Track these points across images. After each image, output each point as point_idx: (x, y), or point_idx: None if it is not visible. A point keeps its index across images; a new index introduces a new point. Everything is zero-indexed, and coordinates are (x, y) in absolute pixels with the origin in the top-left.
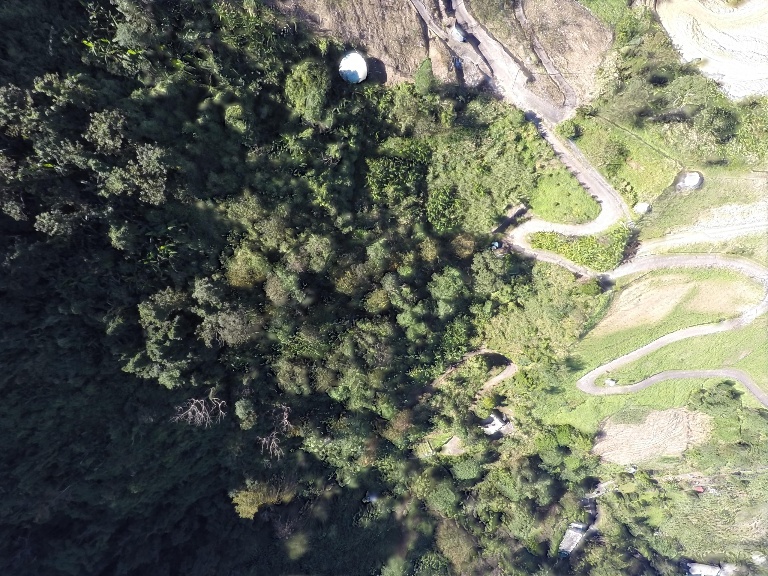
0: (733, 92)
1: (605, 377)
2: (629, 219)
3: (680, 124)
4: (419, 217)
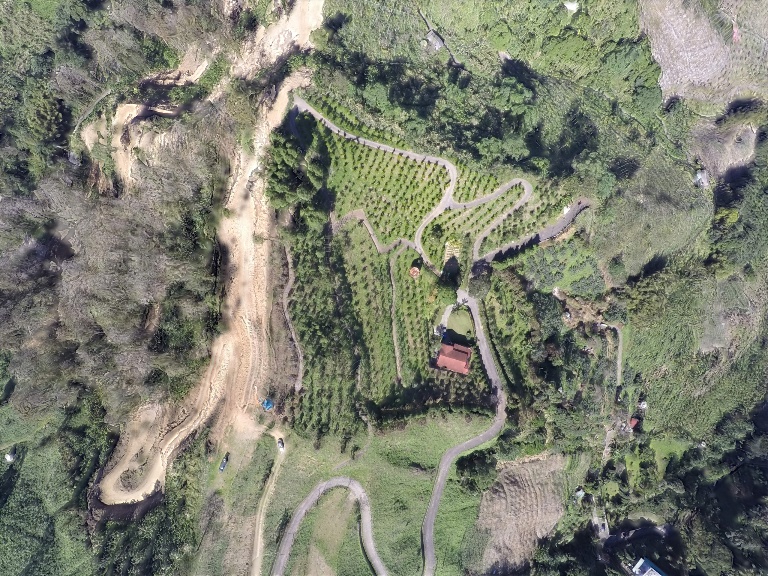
0: None
1: None
2: None
3: None
4: None
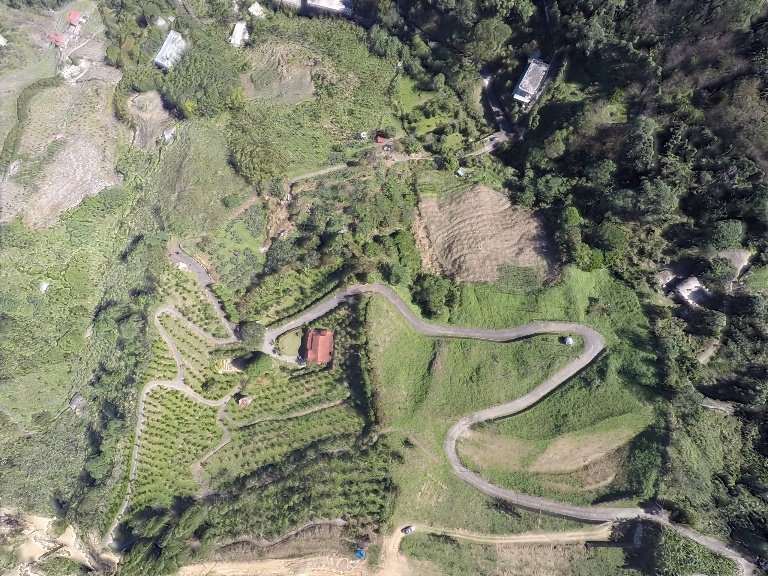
0: None
1: (574, 347)
2: None
3: None
4: None
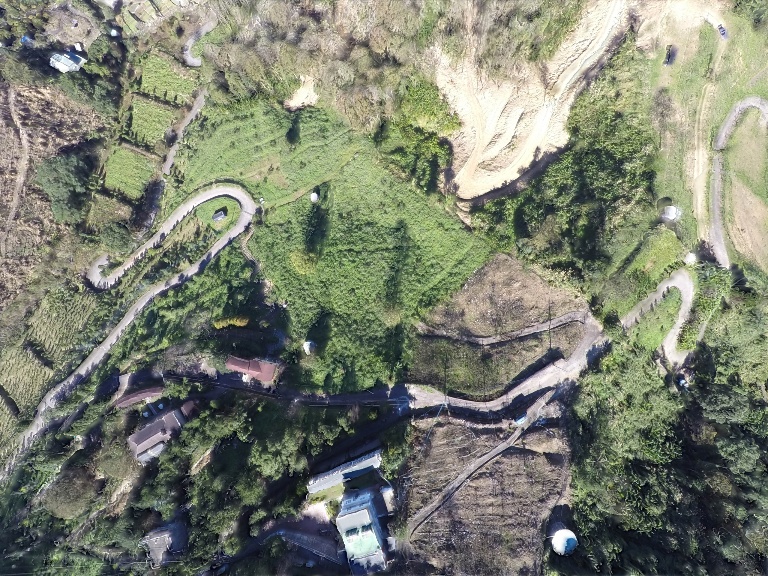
0: (558, 144)
1: None
2: (690, 263)
3: (614, 219)
4: (672, 476)
